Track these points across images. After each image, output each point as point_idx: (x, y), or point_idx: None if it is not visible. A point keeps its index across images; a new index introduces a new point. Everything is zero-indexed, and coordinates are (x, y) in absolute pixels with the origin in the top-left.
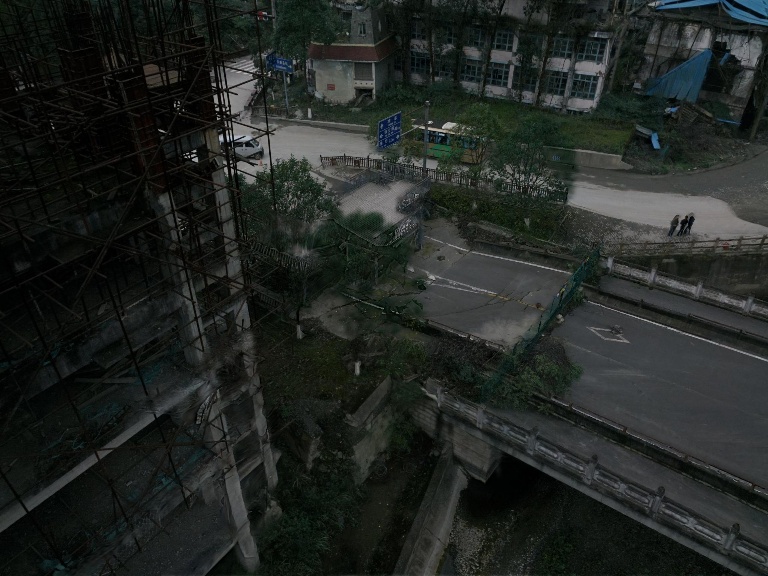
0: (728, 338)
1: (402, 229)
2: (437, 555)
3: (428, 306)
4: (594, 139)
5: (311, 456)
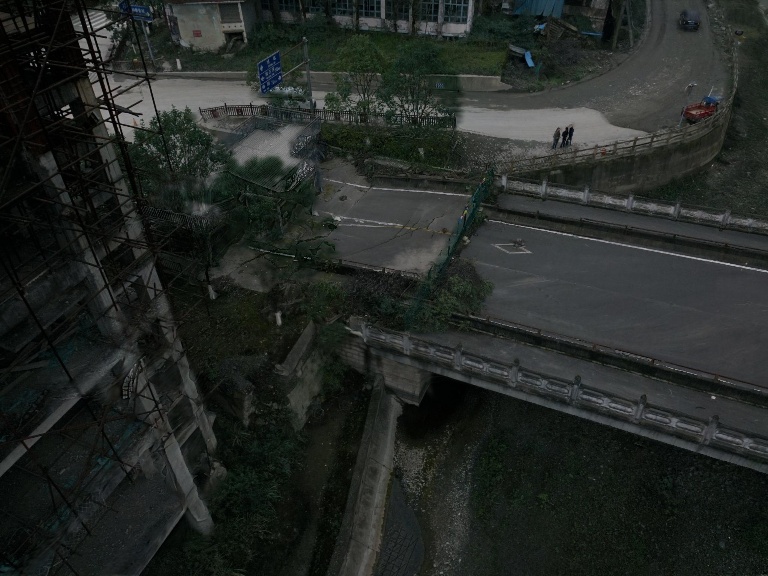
0: (616, 235)
1: (300, 173)
2: (384, 480)
3: (338, 247)
4: (472, 63)
5: (246, 412)
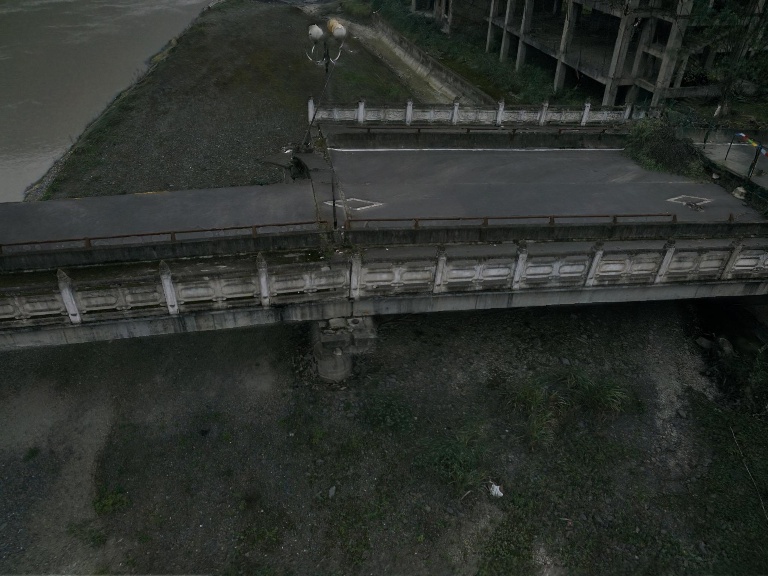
0: None
1: None
2: None
3: None
4: None
5: None
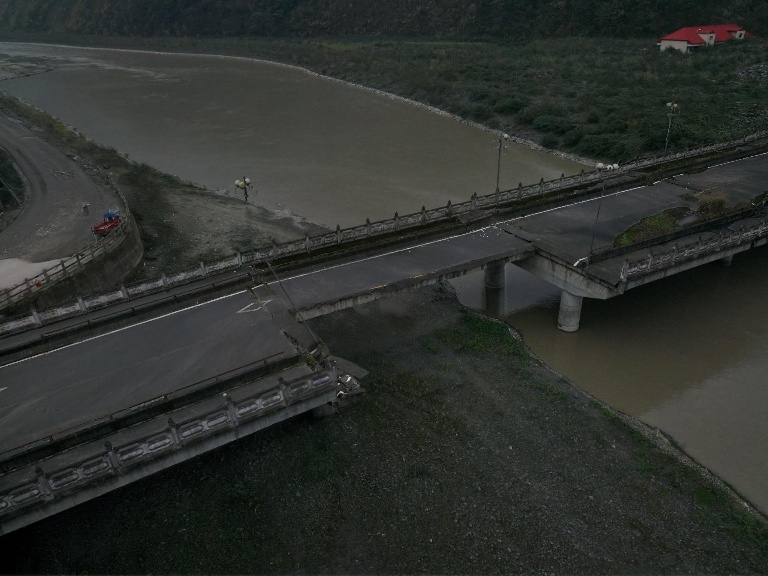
0: (84, 333)
1: None
2: None
3: None
4: None
5: None
